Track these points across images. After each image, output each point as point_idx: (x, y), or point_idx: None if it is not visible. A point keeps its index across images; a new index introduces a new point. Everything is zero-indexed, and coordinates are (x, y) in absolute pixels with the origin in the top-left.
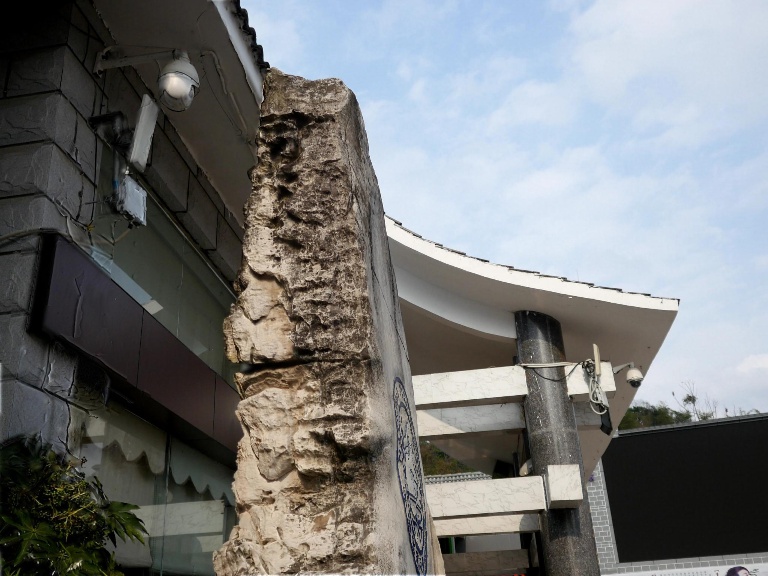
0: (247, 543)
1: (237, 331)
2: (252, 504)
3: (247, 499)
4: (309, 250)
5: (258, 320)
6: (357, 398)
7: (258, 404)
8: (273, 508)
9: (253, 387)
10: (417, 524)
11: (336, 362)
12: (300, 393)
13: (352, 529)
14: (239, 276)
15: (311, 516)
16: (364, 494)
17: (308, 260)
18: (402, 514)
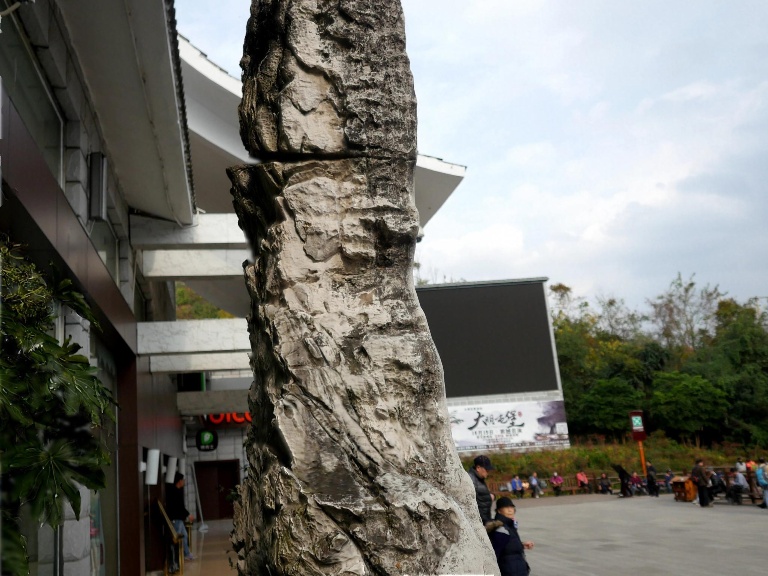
0: (303, 313)
1: (287, 119)
2: (296, 281)
3: (293, 276)
4: (360, 51)
5: (308, 111)
6: (399, 194)
7: (308, 190)
8: (317, 286)
9: (300, 175)
10: None
11: (383, 159)
12: (347, 184)
13: (397, 305)
14: (282, 66)
15: (353, 294)
16: (400, 278)
17: (360, 60)
18: None
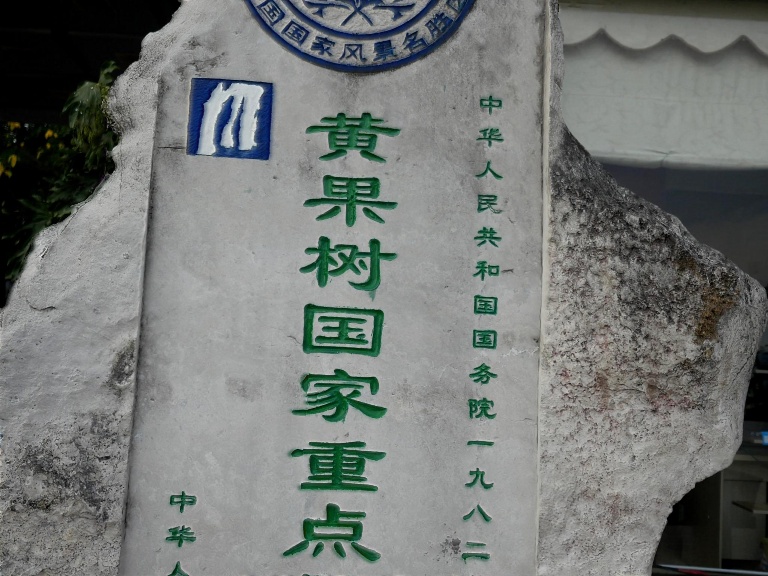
0: None
1: None
2: None
3: None
4: None
5: None
6: None
7: None
8: None
9: None
10: (349, 5)
11: None
12: None
13: None
14: None
15: None
16: None
17: None
18: (228, 3)
